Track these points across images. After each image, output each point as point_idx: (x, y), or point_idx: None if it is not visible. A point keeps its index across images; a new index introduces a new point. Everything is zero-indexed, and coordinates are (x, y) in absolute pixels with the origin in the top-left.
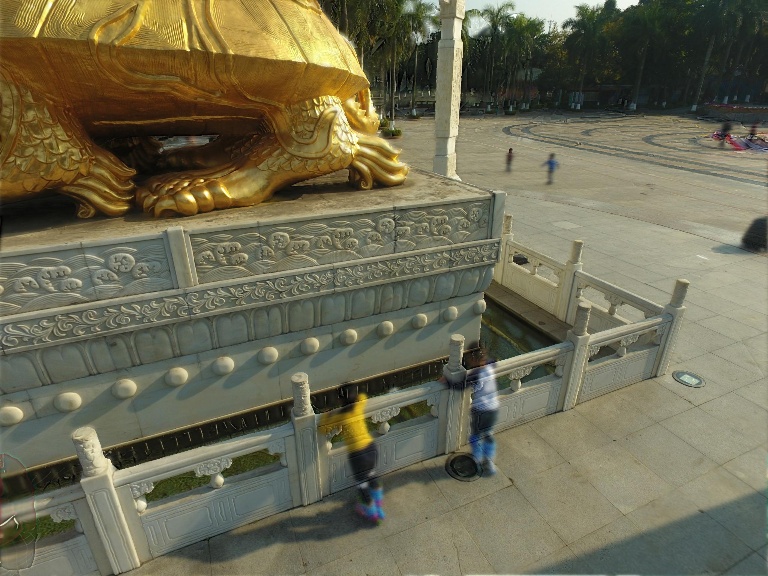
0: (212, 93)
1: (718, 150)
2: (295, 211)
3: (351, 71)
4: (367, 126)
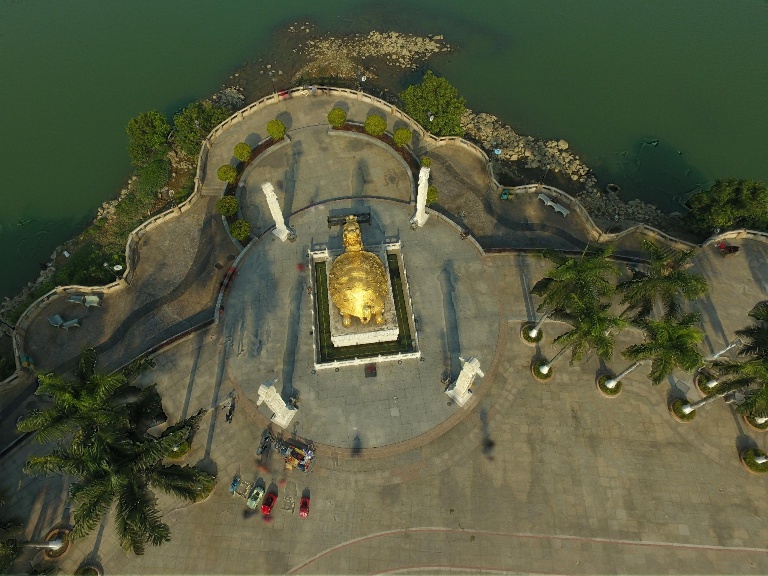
0: None
1: None
2: None
3: (341, 309)
4: None
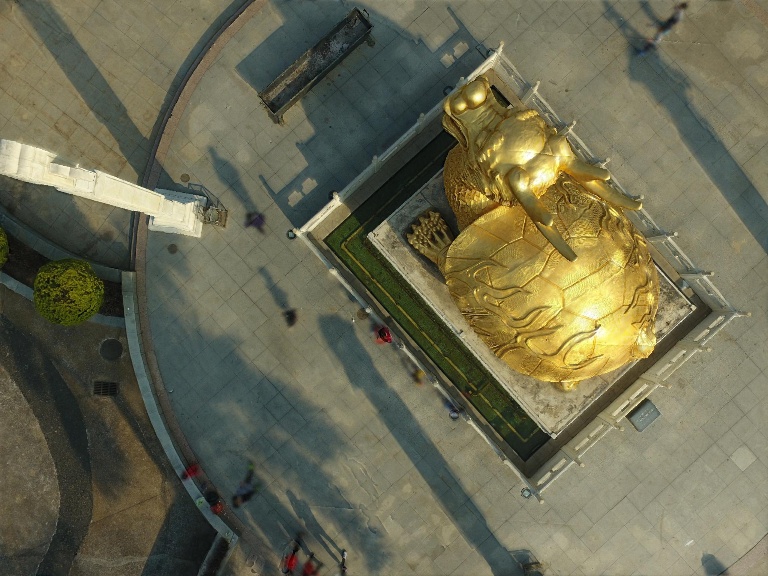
0: None
1: None
2: (501, 360)
3: (561, 381)
4: None
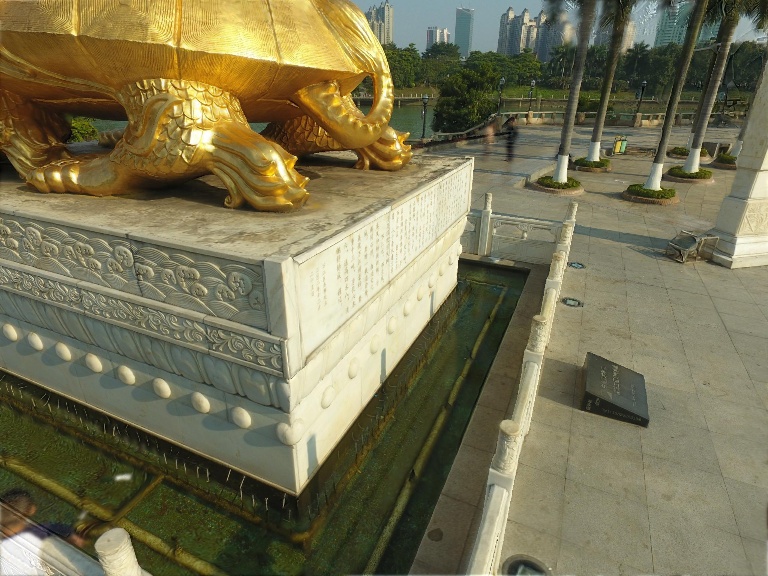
0: (23, 72)
1: None
2: (87, 211)
3: (183, 46)
4: (344, 127)
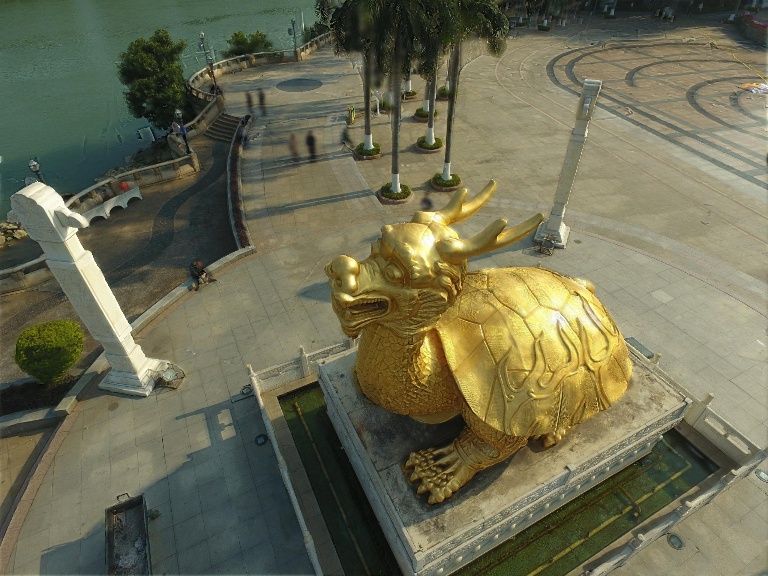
0: None
1: (758, 124)
2: (601, 432)
3: None
4: None
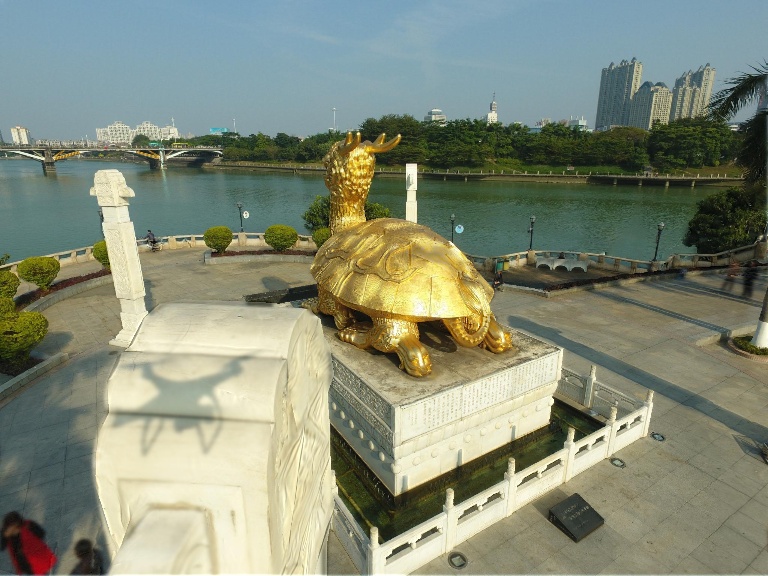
0: None
1: None
2: (353, 358)
3: (393, 312)
4: (459, 339)
